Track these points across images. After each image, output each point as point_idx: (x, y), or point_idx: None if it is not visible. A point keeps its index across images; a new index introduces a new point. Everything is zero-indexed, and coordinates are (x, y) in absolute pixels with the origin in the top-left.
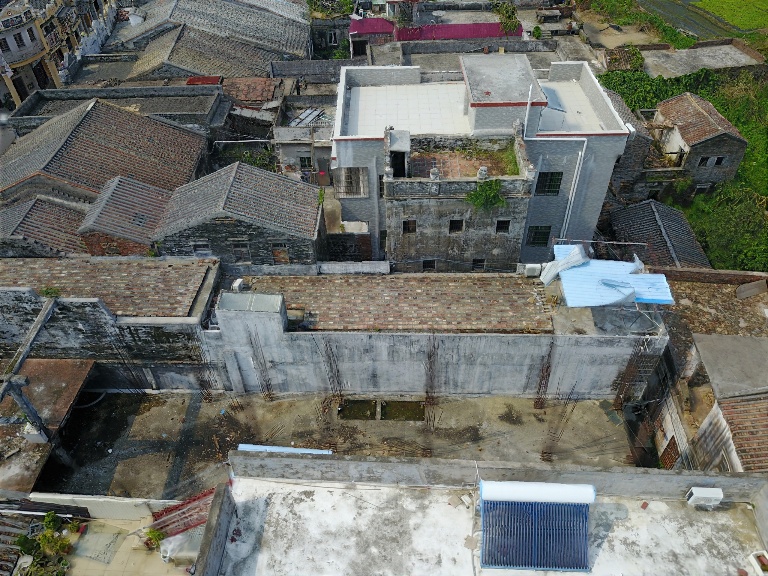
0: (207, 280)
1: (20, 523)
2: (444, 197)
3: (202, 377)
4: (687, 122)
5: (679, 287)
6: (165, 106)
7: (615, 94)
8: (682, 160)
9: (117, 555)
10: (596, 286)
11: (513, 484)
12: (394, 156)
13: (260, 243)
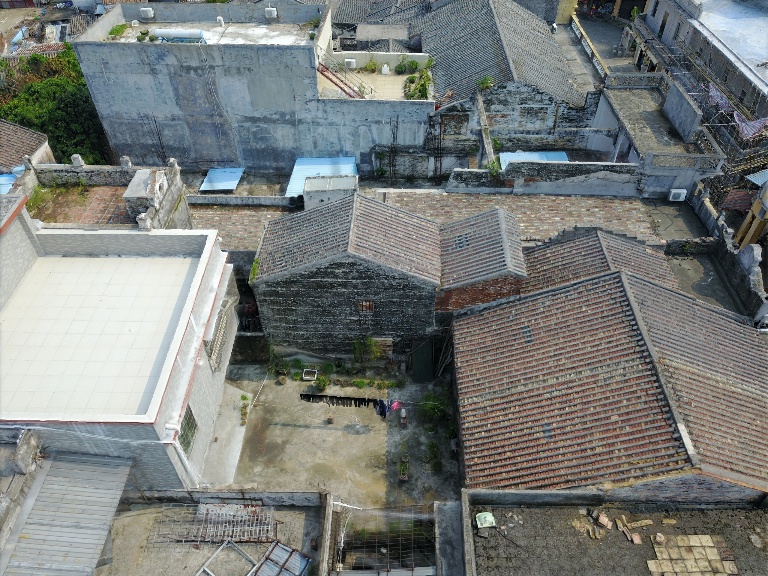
0: None
1: None
2: None
3: None
4: None
5: None
6: None
7: None
8: None
9: None
10: None
11: (187, 30)
12: None
13: None
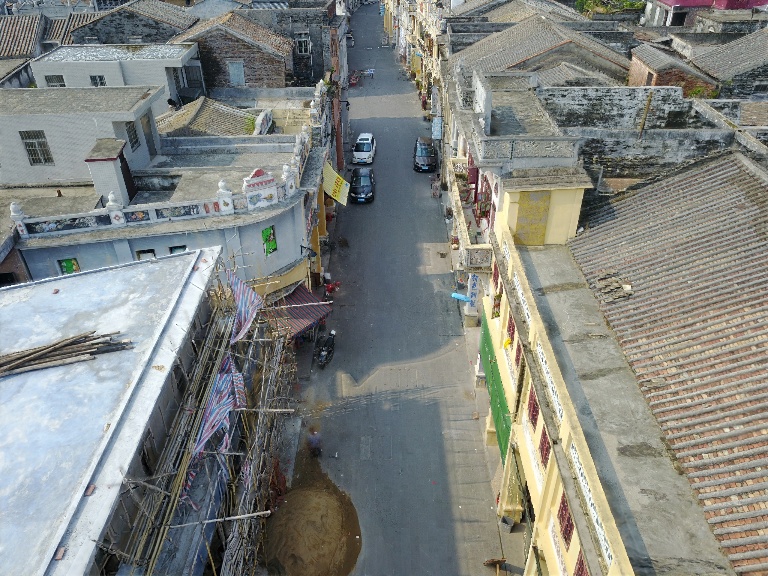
0: None
1: None
2: None
3: None
4: None
5: None
6: None
7: None
8: None
9: None
10: None
11: None
12: None
13: None
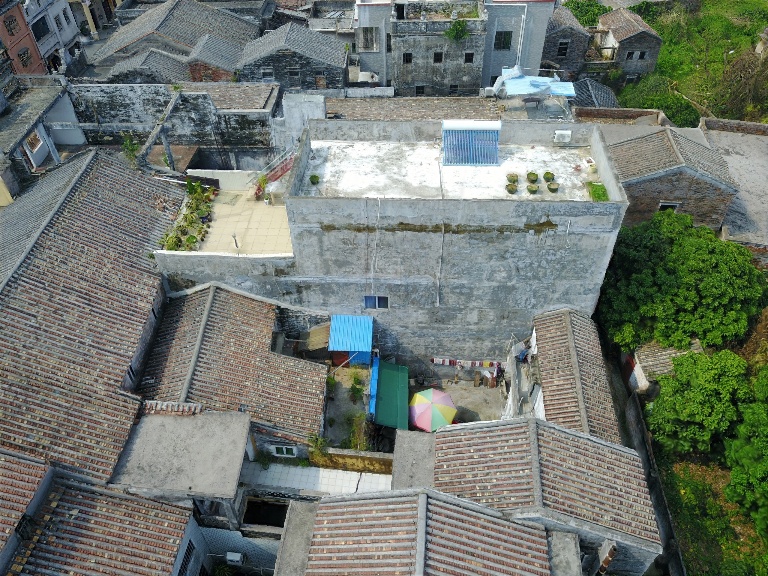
0: (273, 94)
1: (180, 189)
2: (430, 34)
3: (269, 159)
4: (618, 26)
5: (597, 121)
6: (227, 6)
7: (566, 9)
8: (614, 55)
9: (238, 203)
10: (527, 87)
11: (459, 121)
12: (397, 8)
13: (307, 71)
